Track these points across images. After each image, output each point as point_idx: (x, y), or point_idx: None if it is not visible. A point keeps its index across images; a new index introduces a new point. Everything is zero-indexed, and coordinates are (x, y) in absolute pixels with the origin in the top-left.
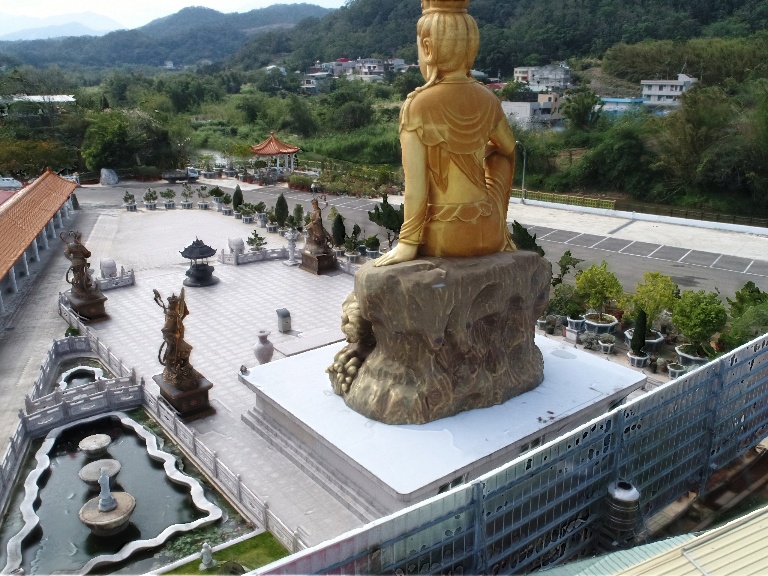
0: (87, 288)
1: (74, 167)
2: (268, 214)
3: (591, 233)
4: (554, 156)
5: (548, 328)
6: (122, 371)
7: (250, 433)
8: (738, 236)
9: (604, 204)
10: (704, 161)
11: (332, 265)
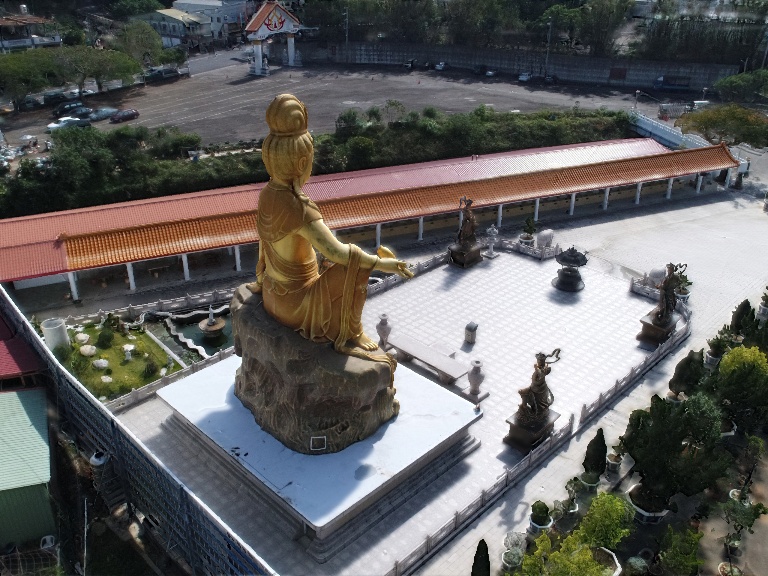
0: None
1: (760, 147)
2: None
3: None
4: None
5: None
6: None
7: None
8: None
9: None
10: None
11: (660, 339)
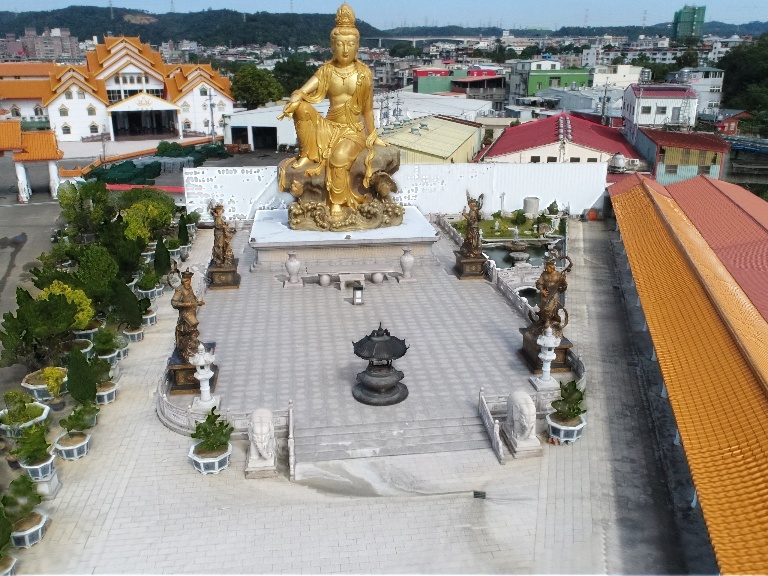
0: None
1: None
2: None
3: None
4: None
5: None
6: None
7: None
8: None
9: None
10: None
11: None
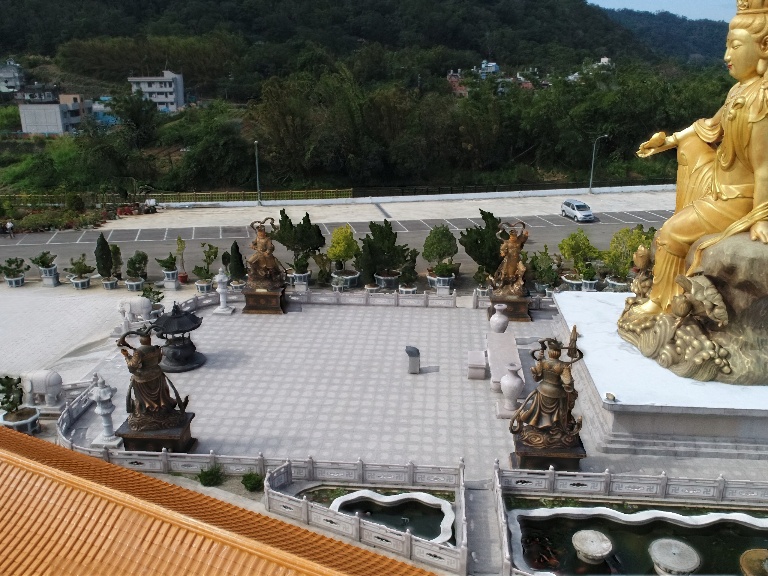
0: (173, 408)
1: None
2: (75, 265)
3: (377, 220)
4: (154, 159)
5: None
6: (417, 475)
7: (641, 458)
8: (465, 203)
9: (343, 194)
10: (311, 148)
11: (284, 299)
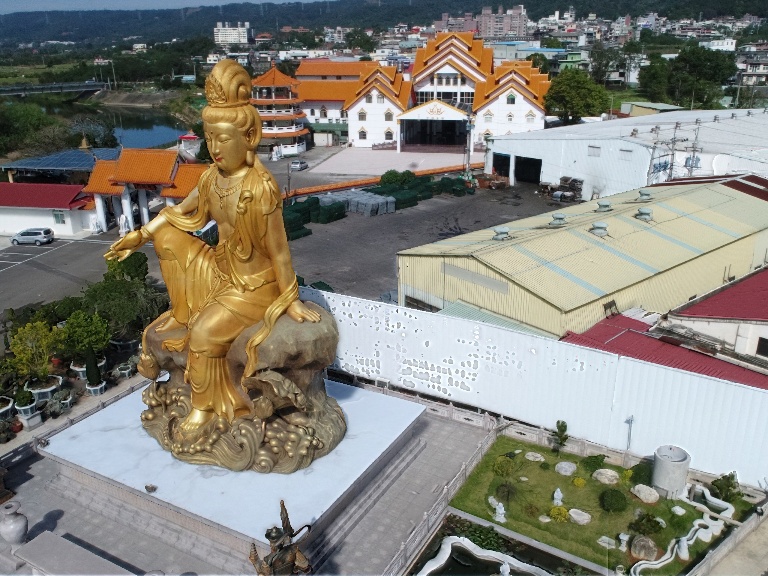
0: None
1: None
2: None
3: None
4: None
5: (6, 436)
6: None
7: (321, 575)
8: None
9: None
10: None
11: None
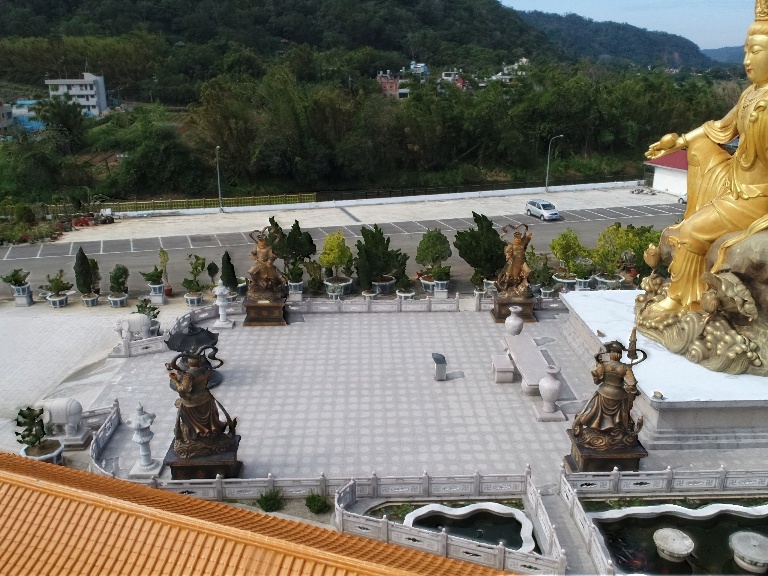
0: None
1: None
2: (52, 282)
3: (347, 224)
4: (90, 165)
5: None
6: (483, 485)
7: (687, 453)
8: (429, 204)
9: (306, 198)
10: (257, 152)
11: (285, 310)
